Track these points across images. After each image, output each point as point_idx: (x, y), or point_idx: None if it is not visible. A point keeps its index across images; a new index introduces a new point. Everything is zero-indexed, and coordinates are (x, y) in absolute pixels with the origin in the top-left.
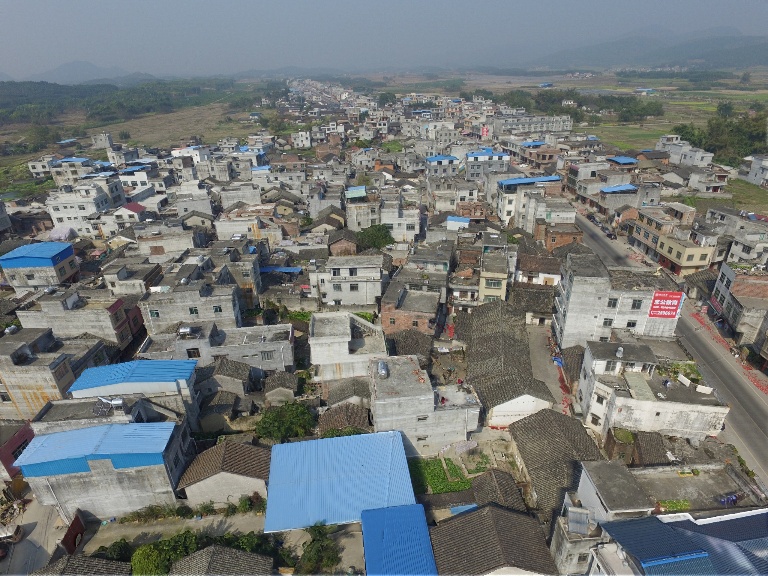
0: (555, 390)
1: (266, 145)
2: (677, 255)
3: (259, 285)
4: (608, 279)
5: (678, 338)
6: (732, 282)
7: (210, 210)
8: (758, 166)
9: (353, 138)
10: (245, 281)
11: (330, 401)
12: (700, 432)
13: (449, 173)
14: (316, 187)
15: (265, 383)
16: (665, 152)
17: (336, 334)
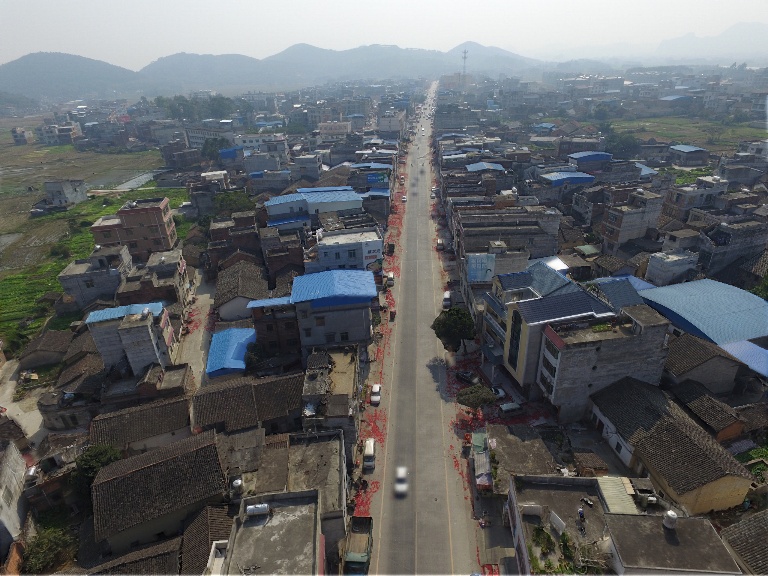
0: None
1: None
2: None
3: None
4: None
5: None
6: None
7: None
8: None
9: None
10: None
11: None
12: None
13: None
14: None
15: None
16: None
17: None
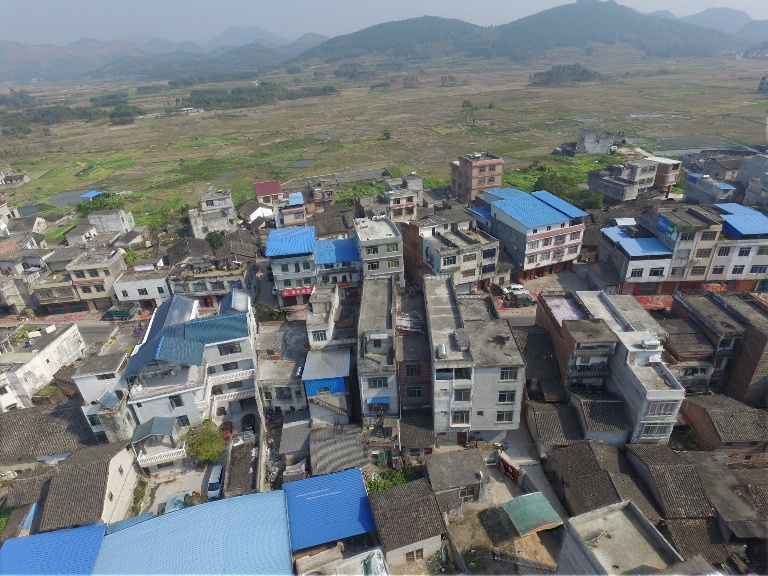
0: None
1: None
2: None
3: None
4: None
5: None
6: None
7: None
8: None
9: None
10: None
11: None
12: (77, 351)
13: None
14: None
15: None
16: None
17: None
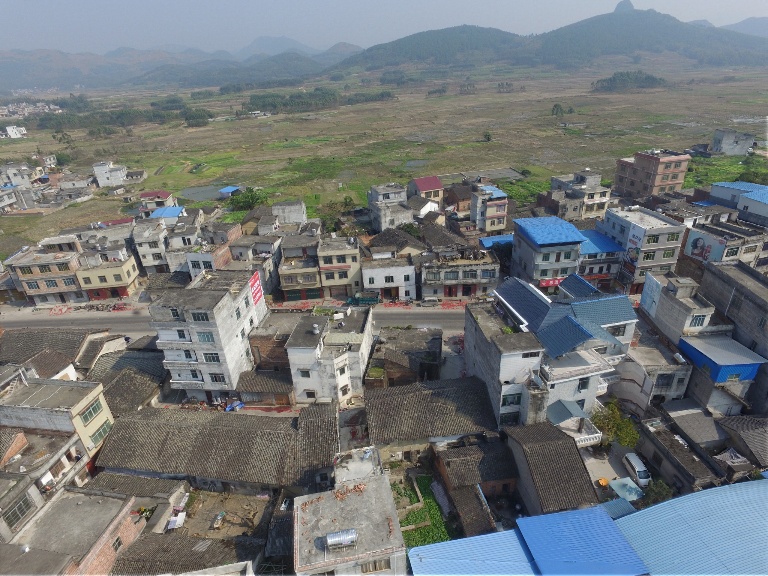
0: None
1: None
2: (116, 279)
3: None
4: (228, 293)
5: None
6: (212, 261)
7: None
8: None
9: None
10: None
11: None
12: None
13: None
14: None
15: None
16: None
17: None
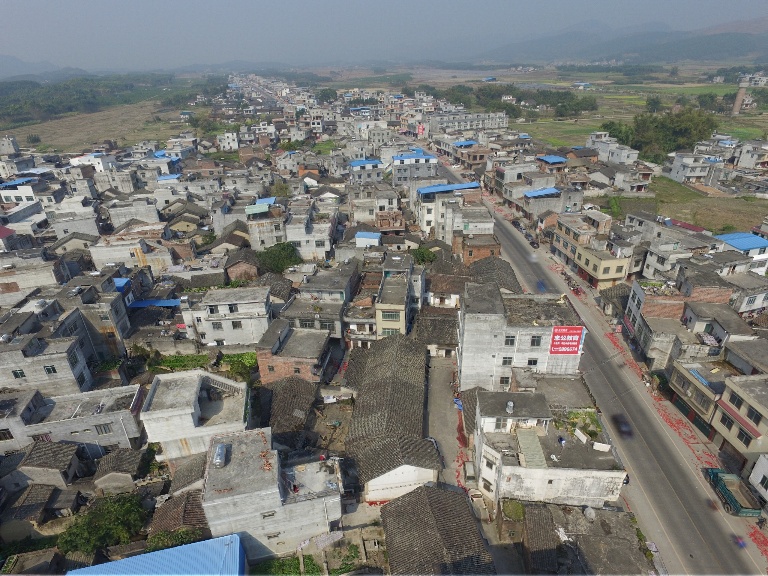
0: (451, 443)
1: (185, 149)
2: (593, 268)
3: (126, 327)
4: (502, 315)
5: (584, 373)
6: (642, 303)
7: (96, 230)
8: (679, 163)
9: (285, 139)
10: (104, 325)
11: (173, 487)
12: (598, 498)
13: (374, 178)
14: (222, 199)
15: (100, 464)
16: (594, 150)
17: (179, 403)
